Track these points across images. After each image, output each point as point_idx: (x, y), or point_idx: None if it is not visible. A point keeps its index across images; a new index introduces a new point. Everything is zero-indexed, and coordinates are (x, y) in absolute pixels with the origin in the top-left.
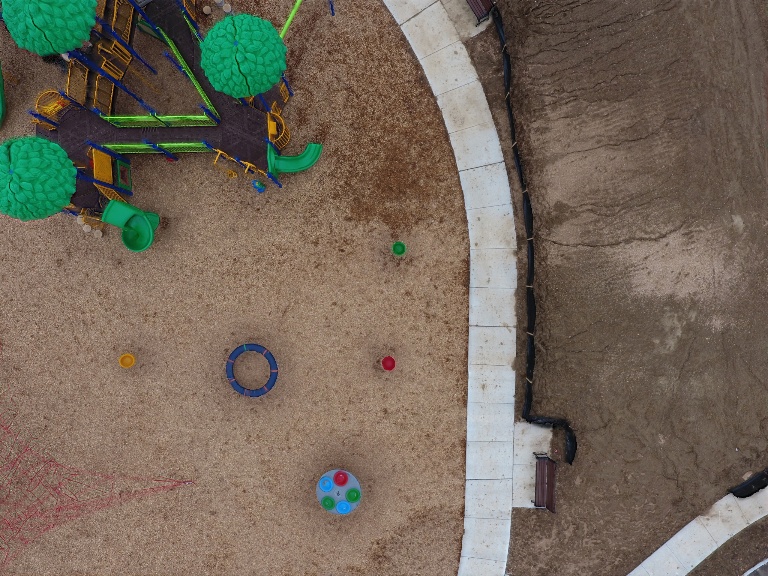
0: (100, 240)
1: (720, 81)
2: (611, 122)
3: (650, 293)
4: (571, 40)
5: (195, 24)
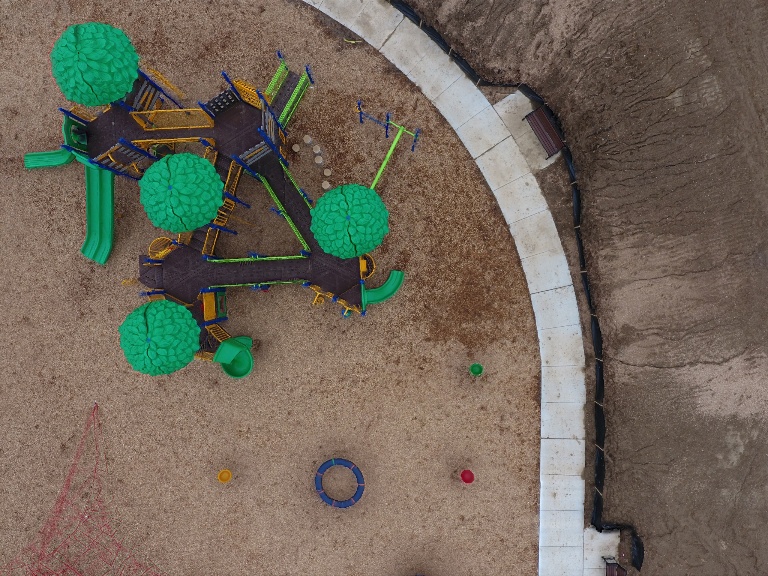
0: (198, 361)
1: None
2: (676, 254)
3: (714, 413)
4: (637, 177)
5: (286, 162)
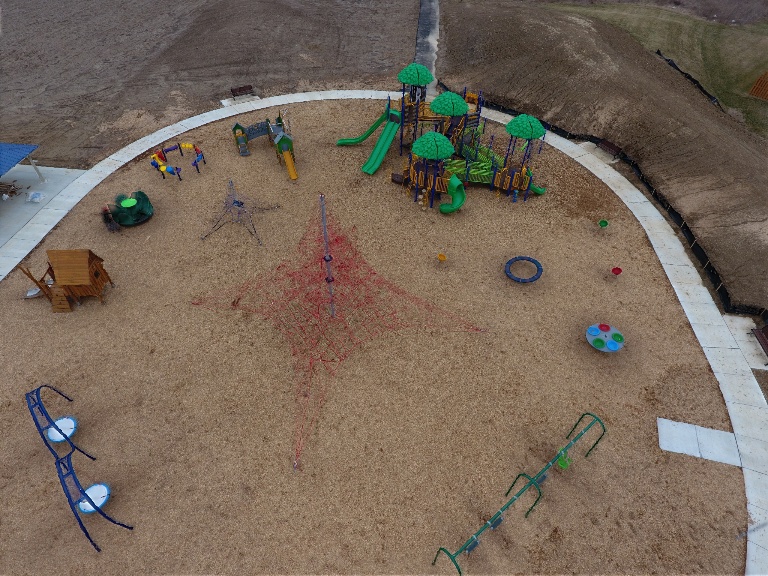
0: (422, 213)
1: (755, 166)
2: (705, 182)
3: None
4: (666, 160)
5: None
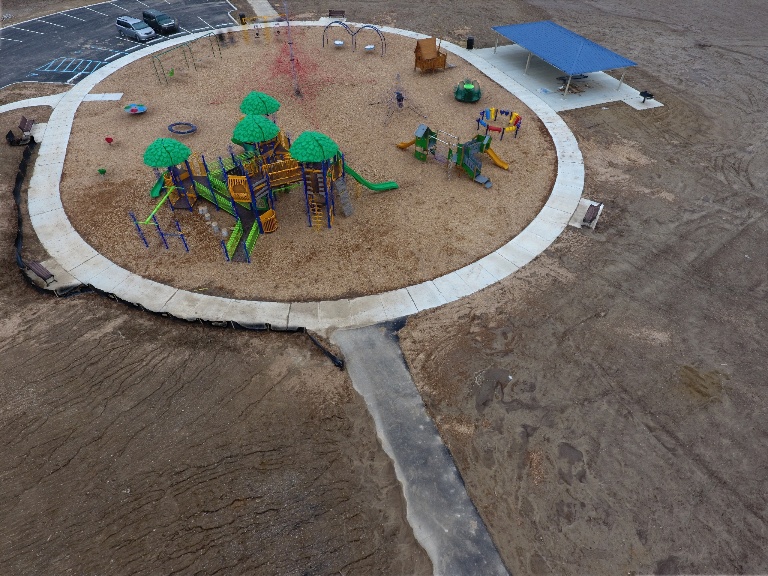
0: None
1: None
2: None
3: None
4: None
5: None
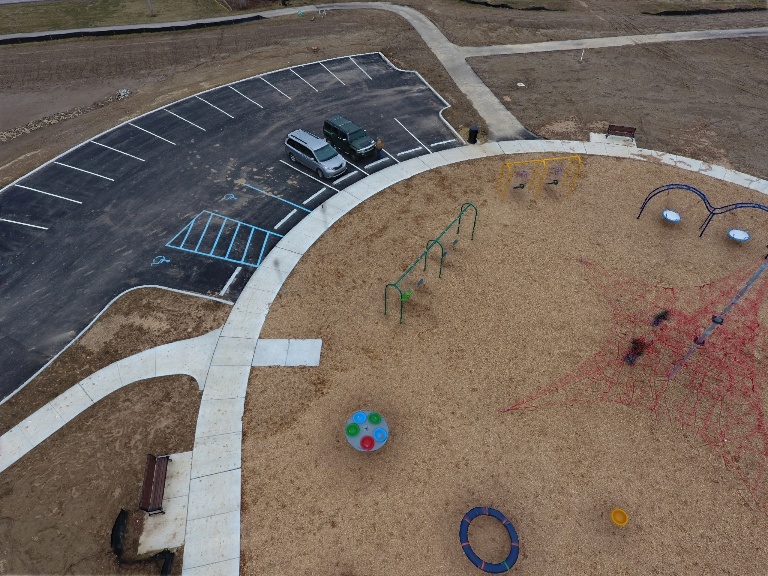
0: None
1: None
2: None
3: None
4: None
5: None
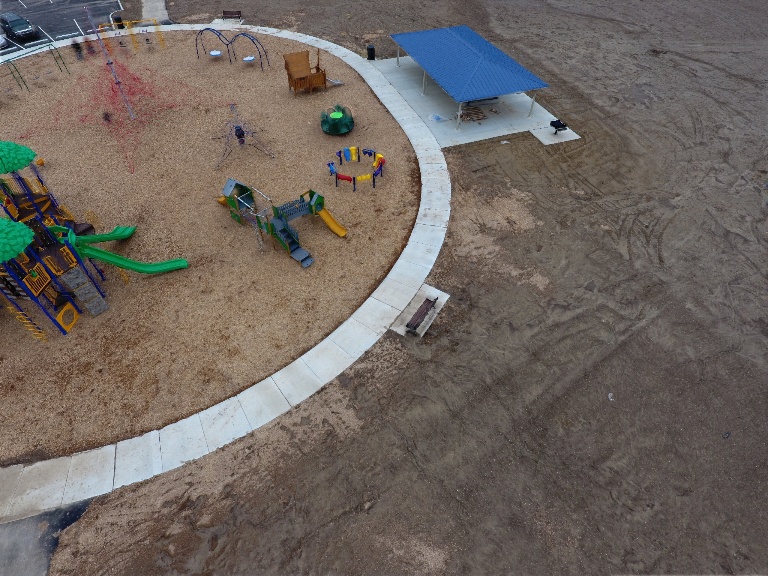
0: None
1: None
2: None
3: None
4: None
5: None
